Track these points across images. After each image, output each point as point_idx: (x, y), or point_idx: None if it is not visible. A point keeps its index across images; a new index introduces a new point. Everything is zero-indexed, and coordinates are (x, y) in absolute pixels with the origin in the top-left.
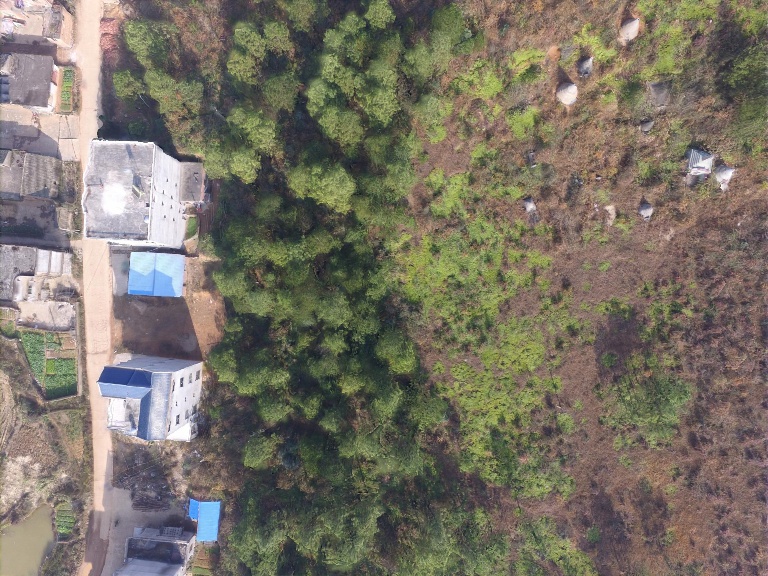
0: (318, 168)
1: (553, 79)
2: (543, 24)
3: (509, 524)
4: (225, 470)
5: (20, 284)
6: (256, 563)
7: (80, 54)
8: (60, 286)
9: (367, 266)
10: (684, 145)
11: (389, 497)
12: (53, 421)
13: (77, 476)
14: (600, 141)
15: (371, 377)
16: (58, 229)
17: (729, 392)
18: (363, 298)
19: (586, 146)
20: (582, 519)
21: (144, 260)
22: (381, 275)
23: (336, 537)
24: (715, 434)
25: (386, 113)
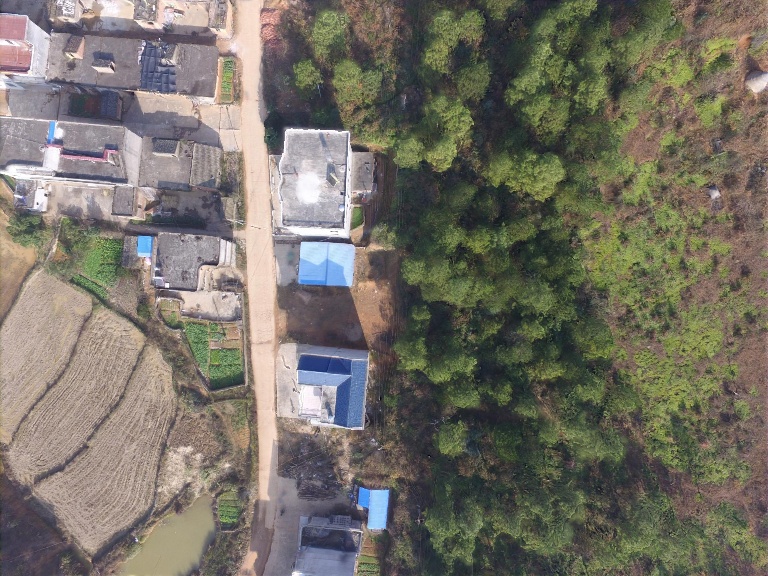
0: (534, 155)
1: (742, 67)
2: (742, 12)
3: (690, 509)
4: (405, 458)
5: (201, 274)
6: (449, 549)
7: (241, 45)
8: (224, 276)
9: (566, 253)
10: None
11: (573, 483)
12: (217, 411)
13: (242, 466)
14: None
15: (574, 363)
16: (220, 220)
17: None
18: (565, 285)
19: None
20: (758, 504)
21: (315, 250)
22: None
23: (540, 522)
24: None
25: None
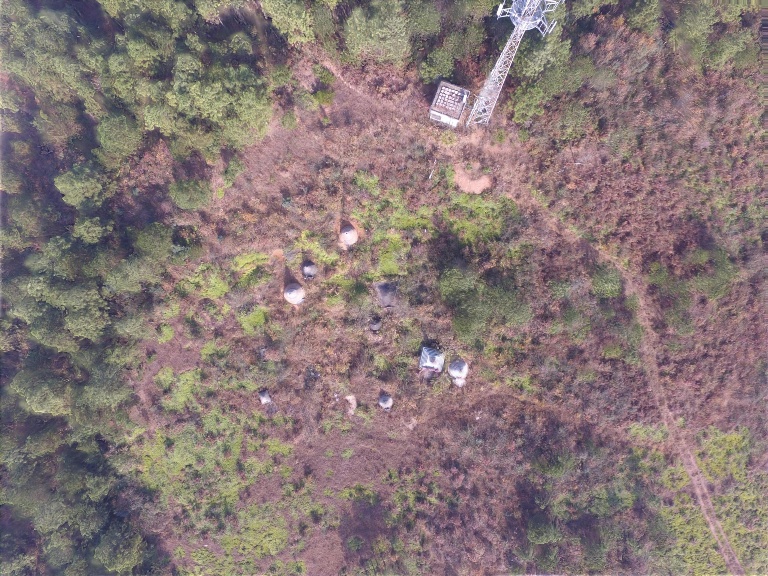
0: (20, 388)
1: (280, 279)
2: (256, 235)
3: None
4: None
5: None
6: None
7: None
8: None
9: (90, 466)
10: (418, 341)
11: None
12: None
13: None
14: (332, 337)
15: None
16: None
17: None
18: (82, 500)
19: (316, 343)
20: None
21: None
22: None
23: None
24: None
25: (91, 330)
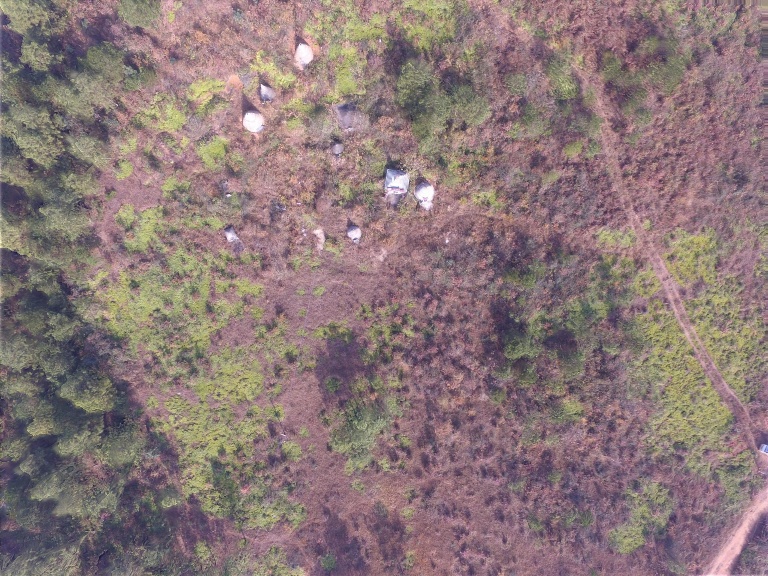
0: None
1: (238, 108)
2: (209, 55)
3: (233, 556)
4: None
5: None
6: None
7: None
8: None
9: (52, 307)
10: (381, 165)
11: (110, 535)
12: None
13: None
14: (294, 166)
15: (56, 419)
16: None
17: (458, 411)
18: (45, 340)
19: (279, 172)
20: (314, 547)
21: None
22: (78, 314)
23: None
24: (448, 454)
25: (44, 155)
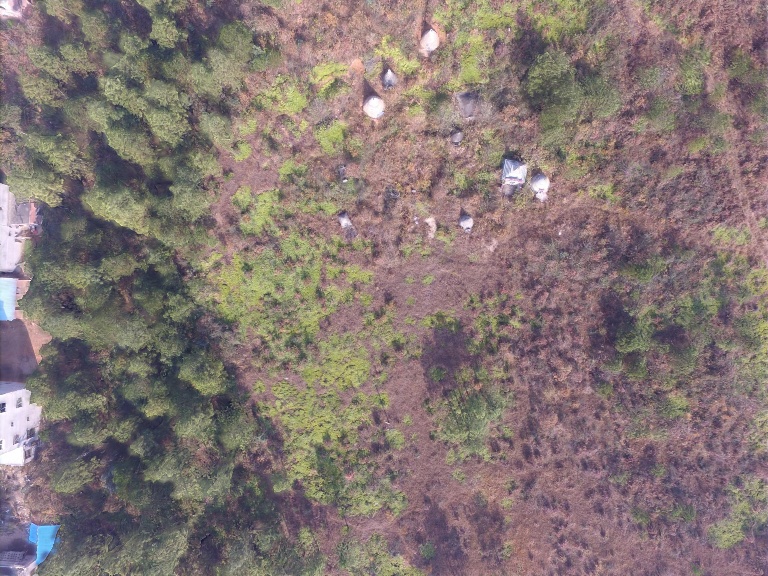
0: (100, 192)
1: (359, 92)
2: (337, 38)
3: (336, 543)
4: (54, 494)
5: None
6: None
7: None
8: None
9: (169, 288)
10: (499, 155)
11: (213, 518)
12: None
13: None
14: (412, 154)
15: (173, 400)
16: None
17: (562, 403)
18: (163, 320)
19: (397, 159)
20: (415, 535)
21: None
22: (191, 296)
23: None
24: (550, 446)
25: (172, 134)
